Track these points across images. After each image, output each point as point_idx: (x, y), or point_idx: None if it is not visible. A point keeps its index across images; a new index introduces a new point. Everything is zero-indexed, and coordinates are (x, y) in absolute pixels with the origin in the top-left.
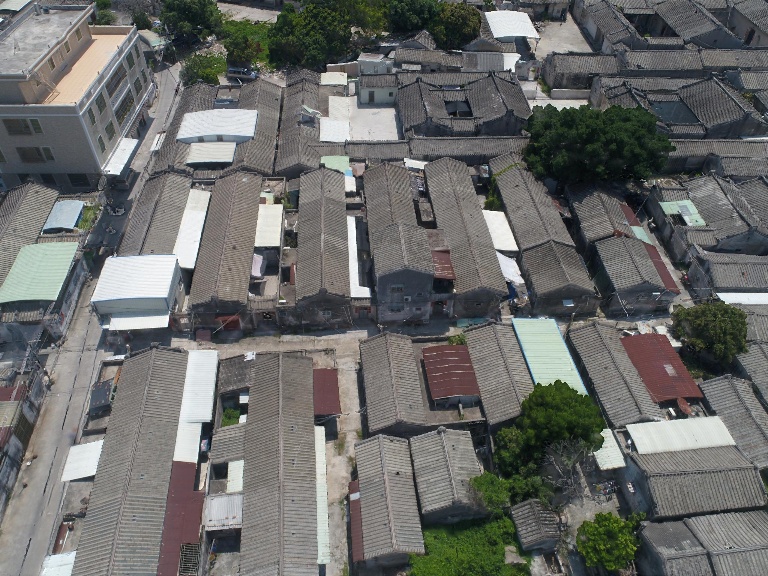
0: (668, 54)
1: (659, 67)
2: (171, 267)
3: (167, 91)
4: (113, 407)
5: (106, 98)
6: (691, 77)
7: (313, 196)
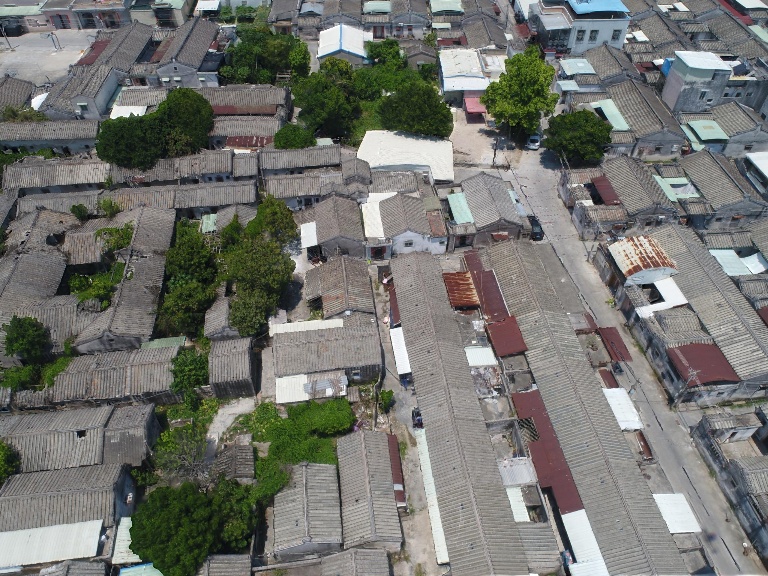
0: None
1: None
2: None
3: None
4: (688, 572)
5: None
6: None
7: None
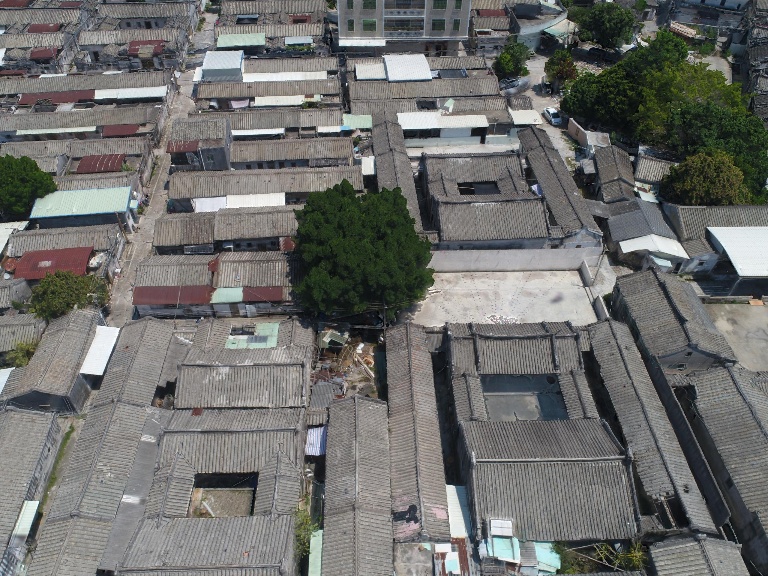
0: (760, 441)
1: (711, 426)
2: (229, 67)
3: None
4: None
5: (380, 5)
6: (704, 483)
7: None
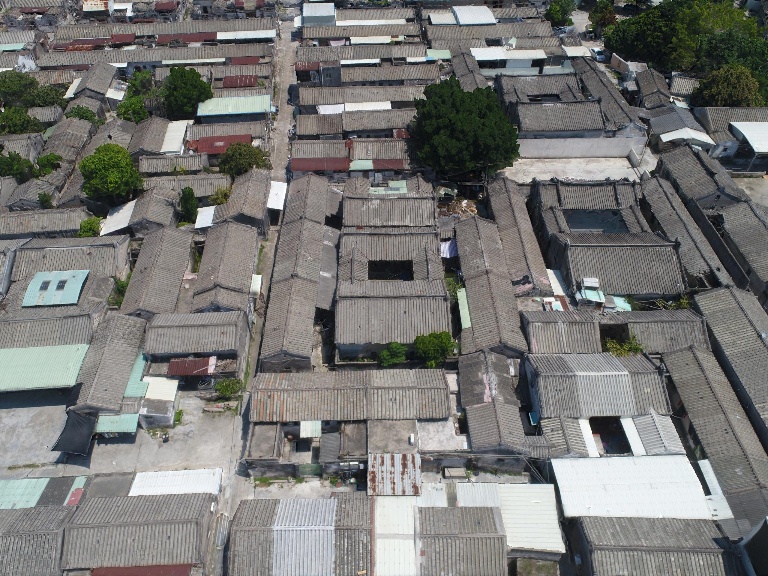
0: None
1: (735, 238)
2: (325, 15)
3: None
4: None
5: None
6: (731, 269)
7: None
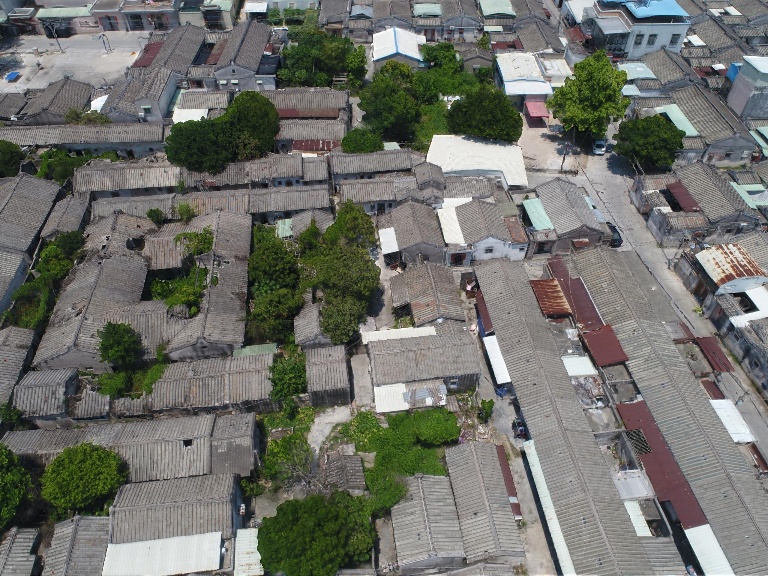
0: None
1: None
2: None
3: None
4: None
5: None
6: None
7: None
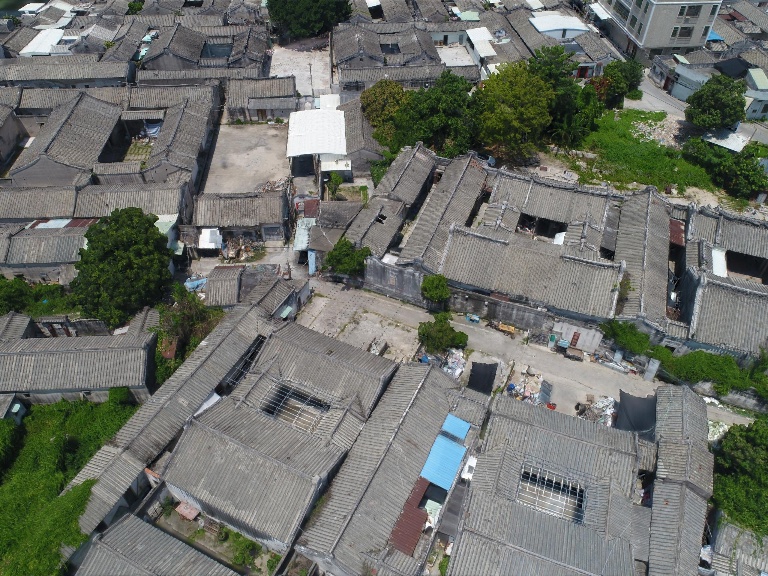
0: None
1: None
2: None
3: (654, 90)
4: None
5: None
6: (159, 85)
7: (473, 0)
